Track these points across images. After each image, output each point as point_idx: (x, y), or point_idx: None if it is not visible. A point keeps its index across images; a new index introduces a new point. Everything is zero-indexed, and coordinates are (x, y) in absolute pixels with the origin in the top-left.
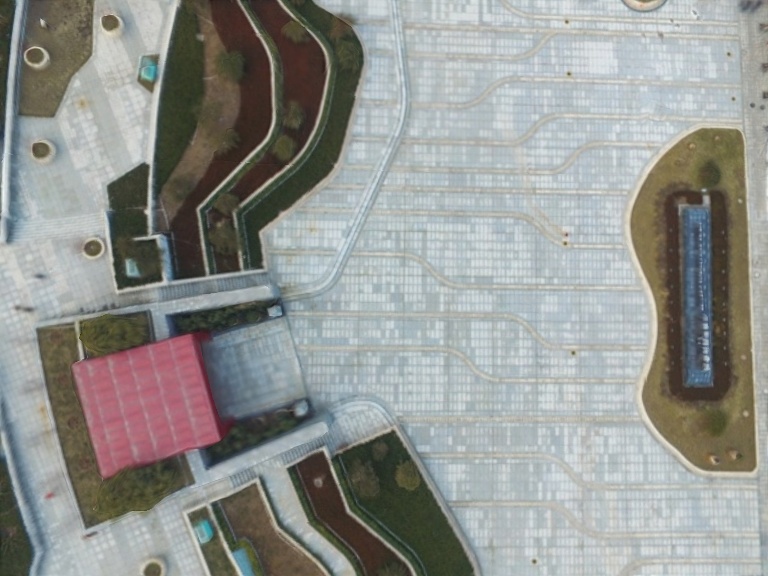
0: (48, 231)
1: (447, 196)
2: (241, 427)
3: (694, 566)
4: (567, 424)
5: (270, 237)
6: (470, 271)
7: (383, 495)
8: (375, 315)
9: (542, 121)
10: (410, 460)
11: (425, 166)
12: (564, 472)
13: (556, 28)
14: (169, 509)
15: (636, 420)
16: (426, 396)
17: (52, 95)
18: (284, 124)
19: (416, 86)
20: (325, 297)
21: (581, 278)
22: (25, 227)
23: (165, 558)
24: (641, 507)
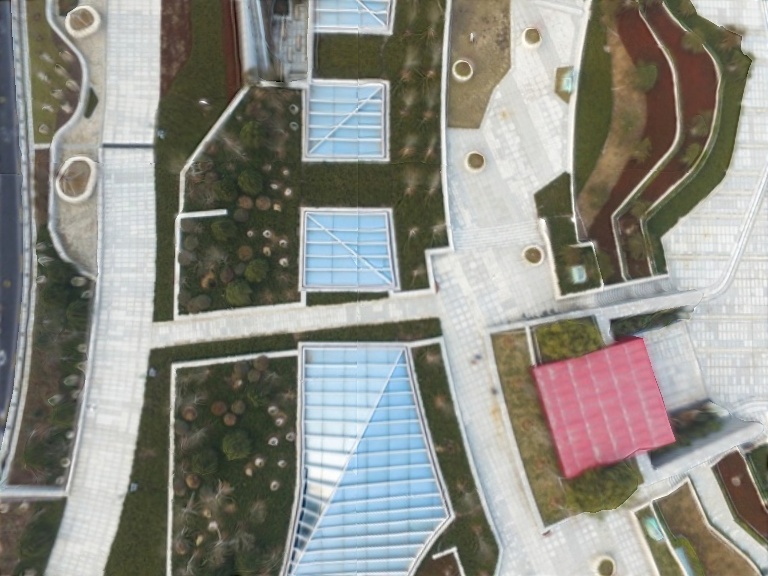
0: (486, 239)
1: None
2: None
3: None
4: None
5: (668, 243)
6: None
7: None
8: (767, 318)
9: None
10: None
11: None
12: None
13: None
14: None
15: None
16: None
17: (476, 107)
18: (694, 133)
19: None
20: (720, 301)
21: None
22: (464, 236)
23: (612, 555)
24: None
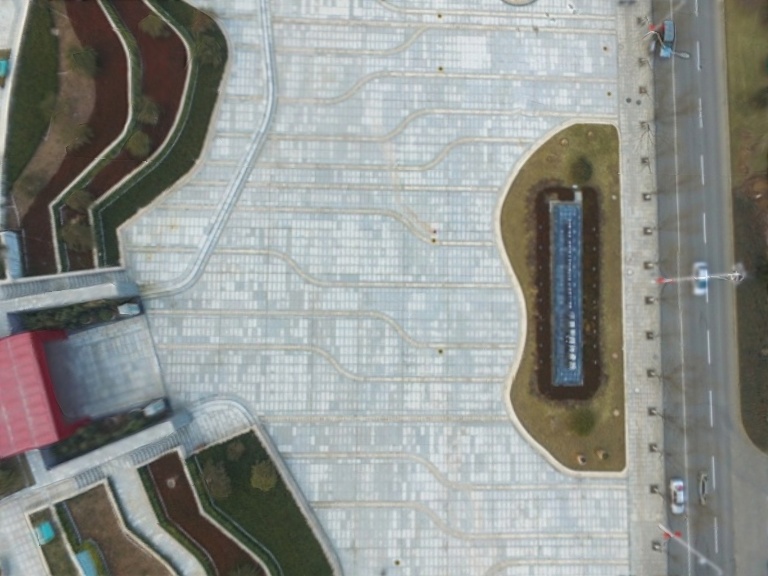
0: None
1: (313, 193)
2: (91, 427)
3: (561, 567)
4: (433, 423)
5: (129, 234)
6: (336, 268)
7: (239, 496)
8: (237, 313)
9: (412, 116)
10: (268, 460)
11: (291, 162)
12: (429, 472)
13: (428, 22)
14: (12, 510)
15: (504, 419)
16: (288, 395)
17: None
18: (138, 119)
19: (283, 81)
20: (186, 295)
21: (449, 276)
22: None
23: (7, 560)
24: (508, 507)
